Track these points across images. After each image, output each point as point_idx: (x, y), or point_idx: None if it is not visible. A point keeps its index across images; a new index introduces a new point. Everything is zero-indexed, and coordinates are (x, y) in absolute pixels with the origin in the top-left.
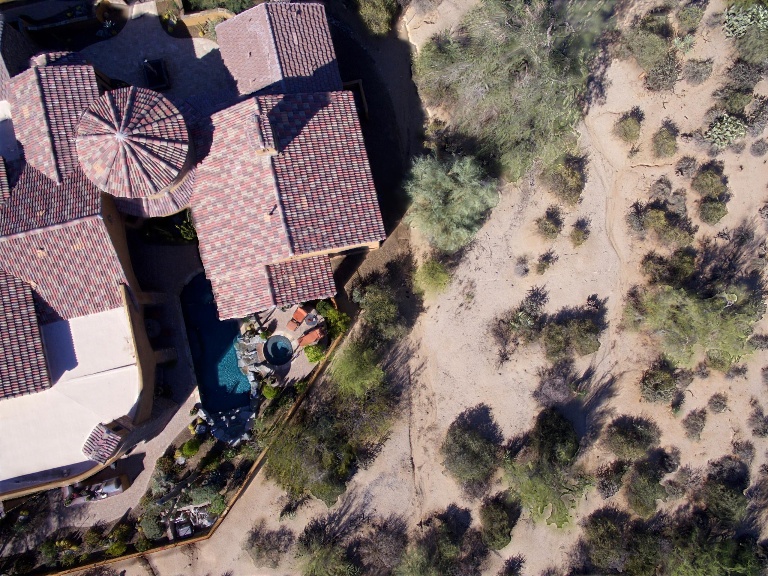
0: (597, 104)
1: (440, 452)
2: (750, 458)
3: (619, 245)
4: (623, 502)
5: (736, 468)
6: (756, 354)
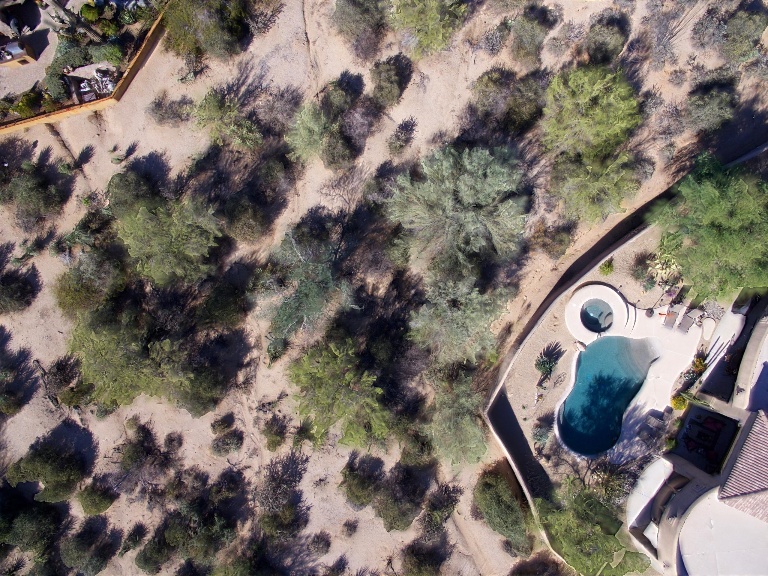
0: None
1: (333, 24)
2: (630, 8)
3: None
4: (509, 60)
5: (615, 14)
6: None
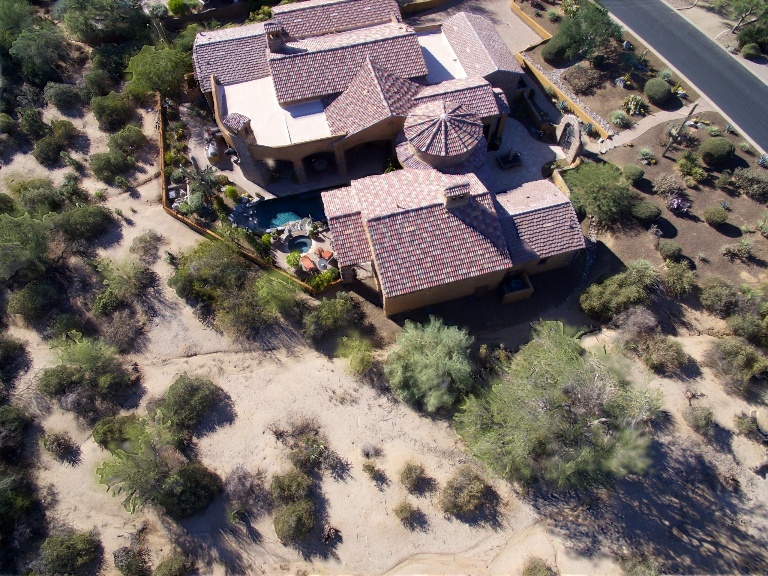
0: (563, 536)
1: None
2: None
3: (400, 572)
4: None
5: None
6: None
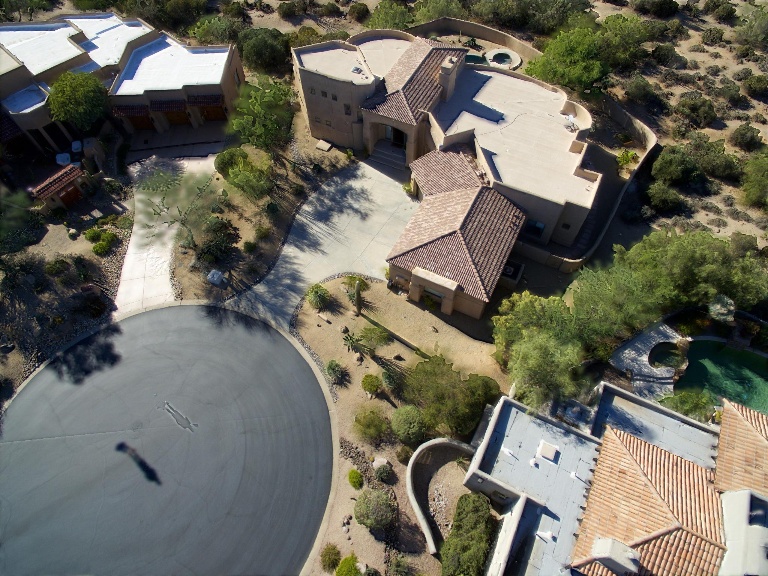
0: None
1: None
2: (691, 67)
3: None
4: None
5: None
6: (755, 67)
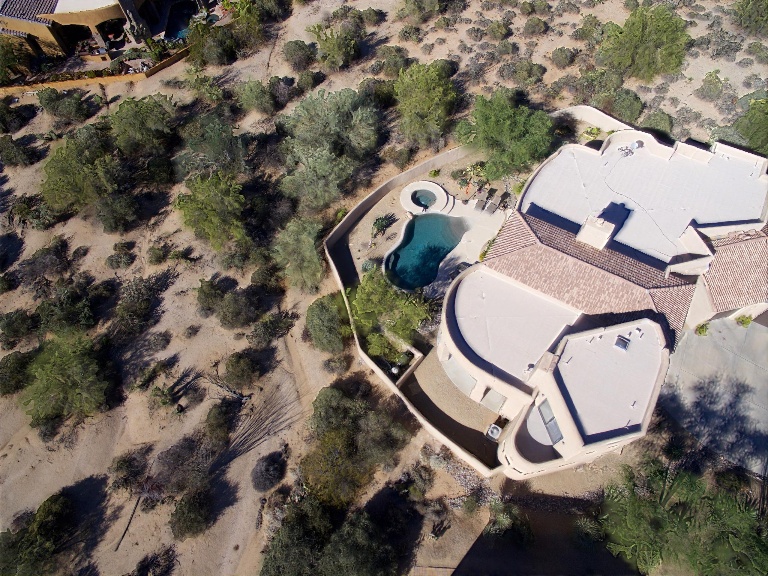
0: None
1: None
2: (458, 60)
3: None
4: None
5: (448, 60)
6: (463, 26)
